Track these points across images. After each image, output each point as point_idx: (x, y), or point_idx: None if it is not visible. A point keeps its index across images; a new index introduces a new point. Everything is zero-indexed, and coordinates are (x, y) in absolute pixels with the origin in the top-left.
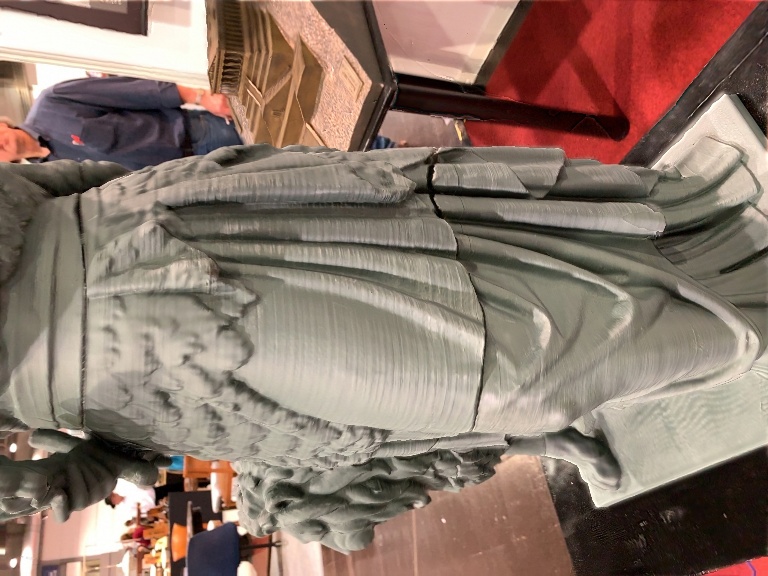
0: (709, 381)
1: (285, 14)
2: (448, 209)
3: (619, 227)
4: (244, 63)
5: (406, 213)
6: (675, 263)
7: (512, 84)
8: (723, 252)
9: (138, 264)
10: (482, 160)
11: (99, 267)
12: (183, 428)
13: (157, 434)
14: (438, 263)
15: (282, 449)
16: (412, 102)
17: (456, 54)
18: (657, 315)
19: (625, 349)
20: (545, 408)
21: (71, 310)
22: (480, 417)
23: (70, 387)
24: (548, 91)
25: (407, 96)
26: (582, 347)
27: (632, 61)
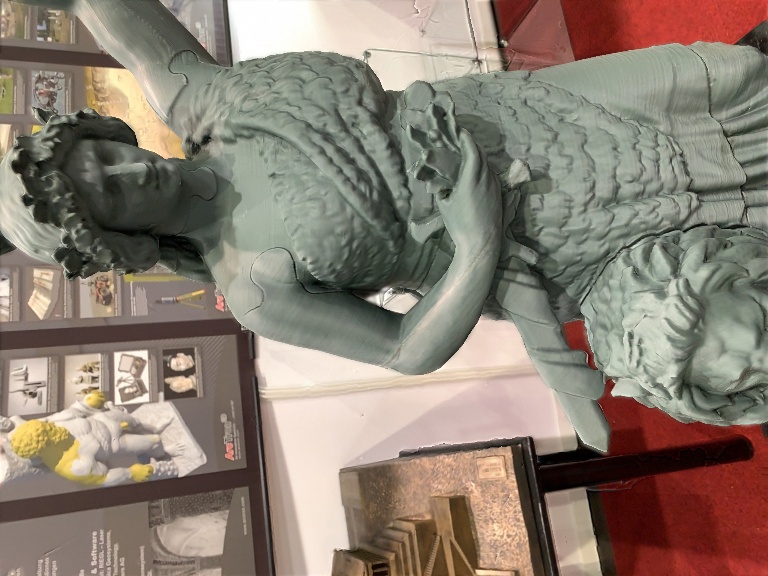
0: None
1: (411, 500)
2: None
3: None
4: (392, 570)
5: None
6: None
7: (636, 544)
8: None
9: None
10: None
11: None
12: (522, 125)
13: (507, 136)
14: None
15: (607, 146)
16: (554, 479)
17: (570, 567)
18: None
19: None
20: None
21: None
22: None
23: None
24: (667, 507)
25: (546, 473)
26: None
27: None
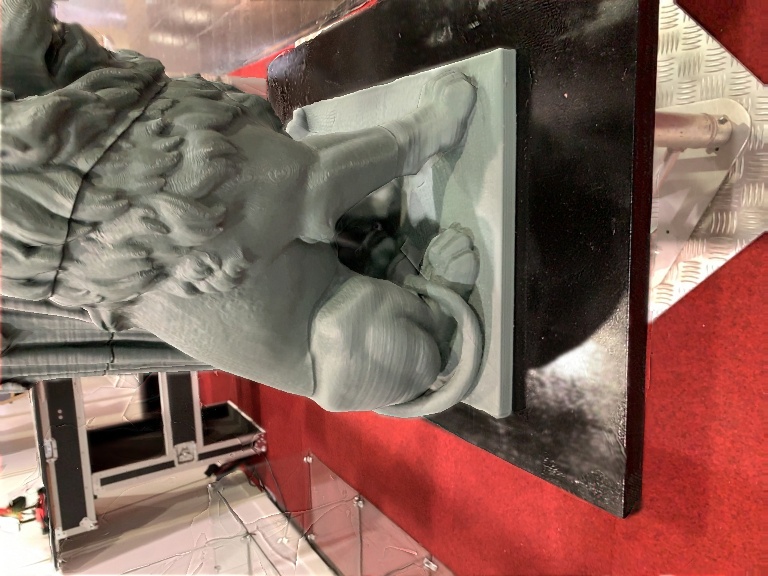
0: None
1: None
2: None
3: None
4: None
5: None
6: None
7: None
8: None
9: None
10: None
11: None
12: None
13: None
14: None
15: None
16: None
17: None
18: None
19: None
20: None
21: None
22: None
23: None
24: None
25: None
26: None
27: None
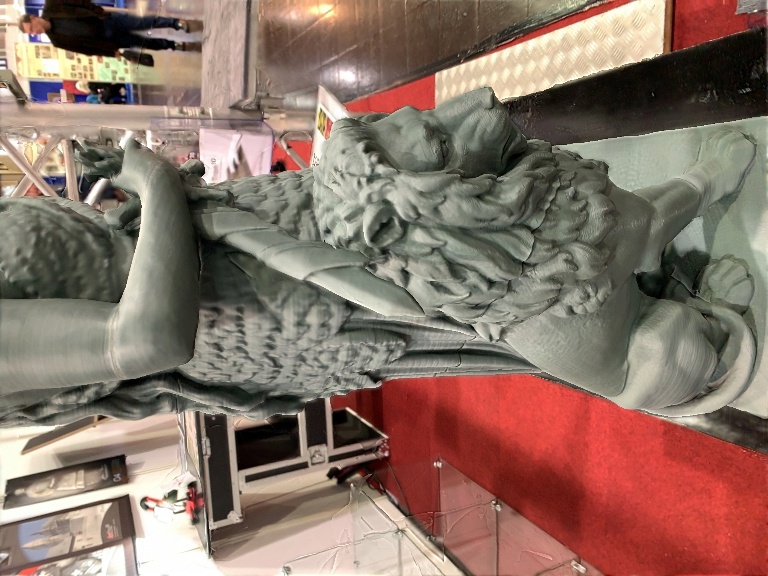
0: None
1: None
2: None
3: None
4: None
5: None
6: None
7: None
8: None
9: None
10: None
11: None
12: None
13: None
14: None
15: None
16: None
17: None
18: None
19: None
20: None
21: None
22: None
23: None
24: None
25: None
26: None
27: None
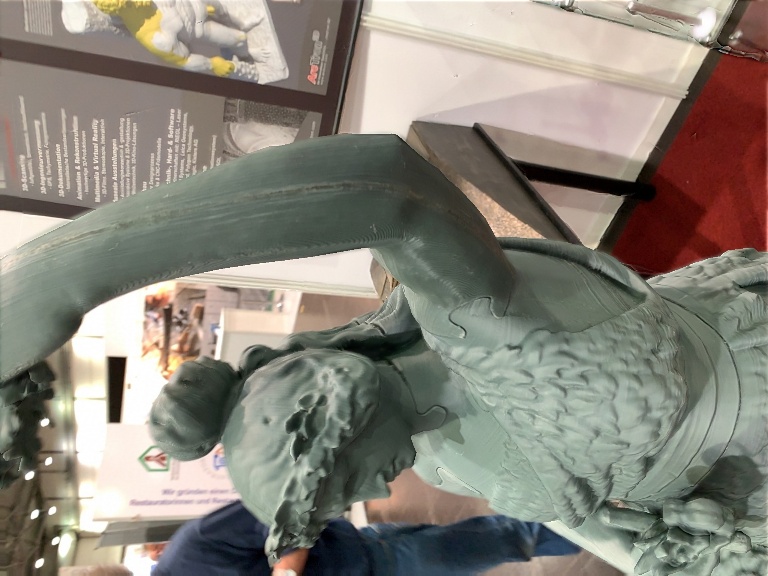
0: None
1: None
2: None
3: None
4: None
5: None
6: None
7: None
8: None
9: (755, 323)
10: None
11: (732, 325)
12: None
13: (764, 488)
14: None
15: None
16: None
17: None
18: None
19: None
20: None
21: (723, 360)
22: None
23: (725, 430)
24: None
25: None
26: None
27: (764, 239)
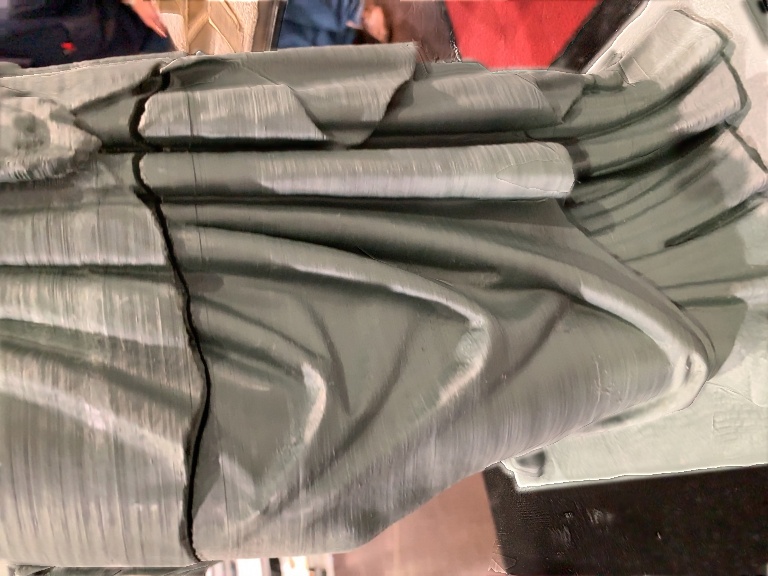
0: (627, 420)
1: None
2: (162, 183)
3: (491, 190)
4: None
5: (75, 197)
6: (594, 233)
7: None
8: (674, 210)
9: None
10: (257, 78)
11: None
12: None
13: None
14: (123, 294)
15: None
16: None
17: None
18: (538, 344)
19: (468, 417)
20: (316, 532)
21: None
22: (204, 552)
23: None
24: None
25: None
26: (387, 425)
27: None
